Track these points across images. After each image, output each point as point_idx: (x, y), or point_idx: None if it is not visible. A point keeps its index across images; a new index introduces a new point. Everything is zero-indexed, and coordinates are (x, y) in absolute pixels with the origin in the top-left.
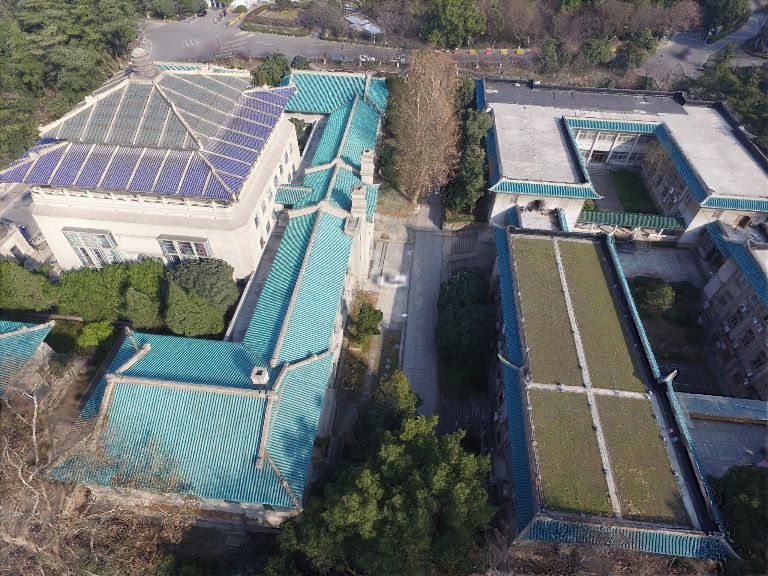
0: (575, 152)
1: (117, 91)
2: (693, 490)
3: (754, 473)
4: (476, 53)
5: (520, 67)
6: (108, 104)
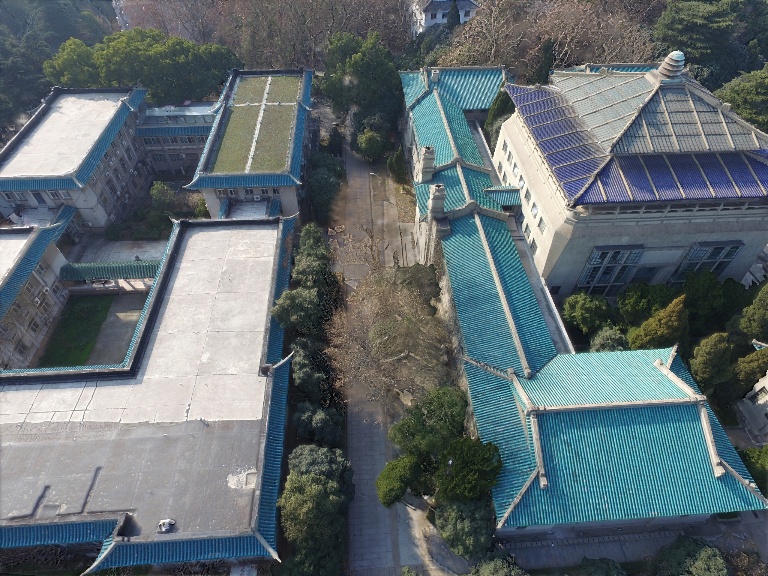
0: None
1: None
2: None
3: (204, 80)
4: None
5: None
6: None
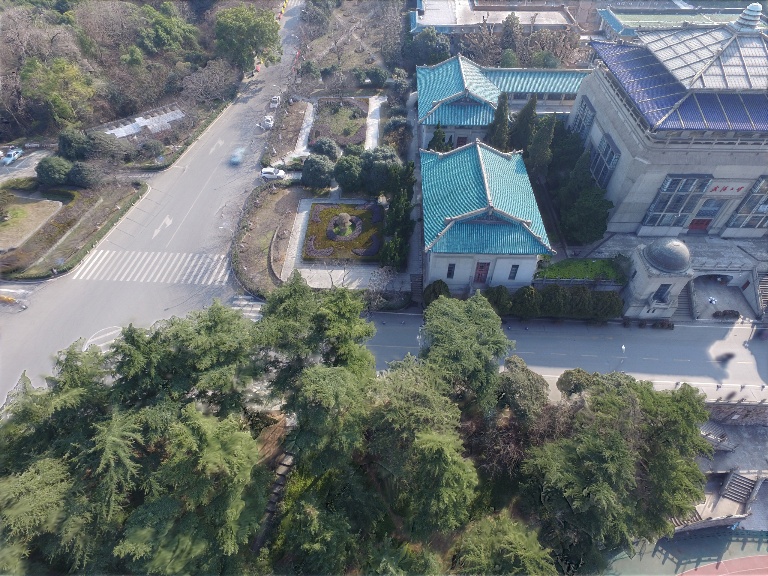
0: (526, 6)
1: None
2: (737, 13)
3: (724, 1)
4: None
5: (311, 39)
6: None
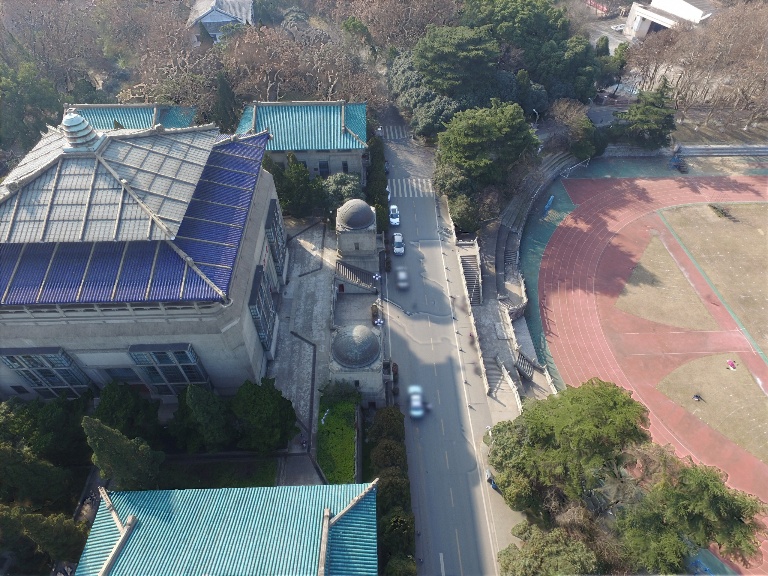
0: None
1: None
2: None
3: None
4: None
5: None
6: None
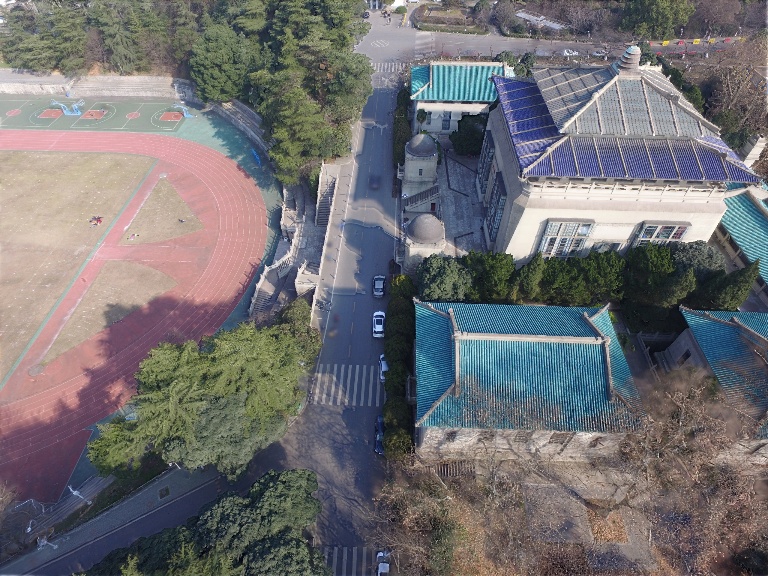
0: None
1: (610, 87)
2: None
3: None
4: (668, 44)
5: None
6: (609, 100)
